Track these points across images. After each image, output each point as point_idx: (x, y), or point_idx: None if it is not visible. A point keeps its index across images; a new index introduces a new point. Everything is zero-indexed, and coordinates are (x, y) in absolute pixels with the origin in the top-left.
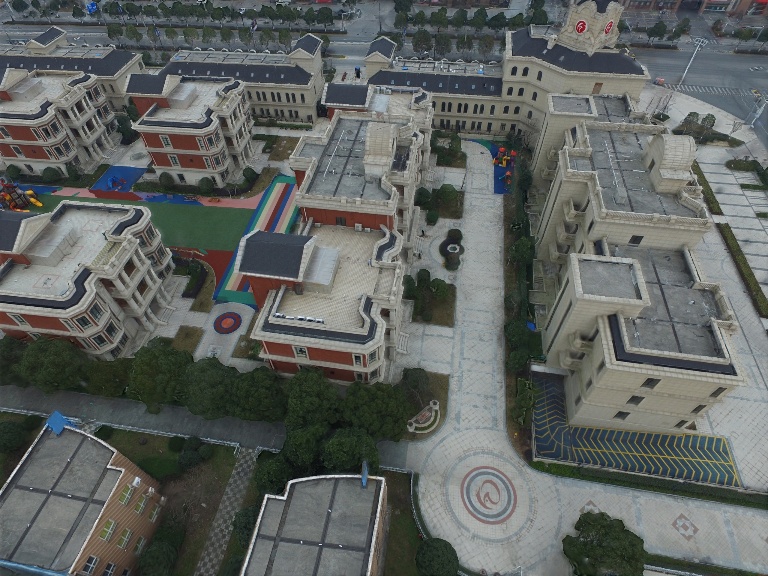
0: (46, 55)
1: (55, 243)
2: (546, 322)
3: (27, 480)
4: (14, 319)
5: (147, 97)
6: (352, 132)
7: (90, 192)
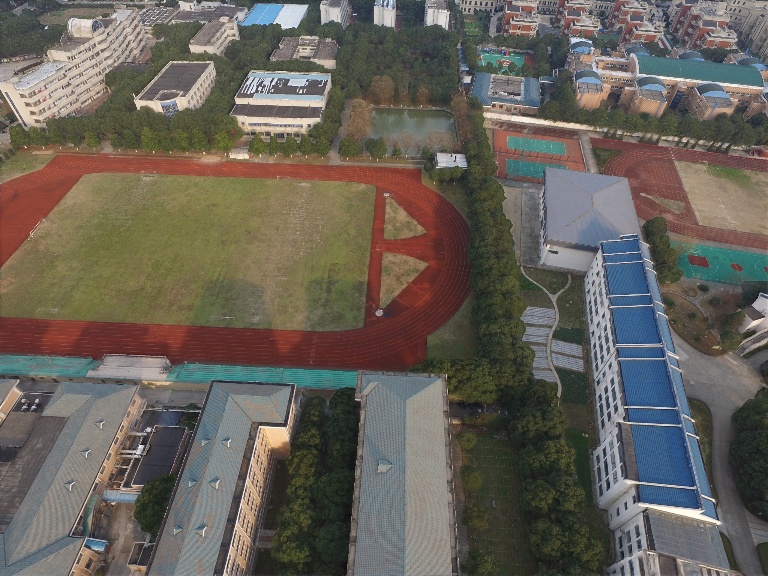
0: None
1: None
2: (761, 55)
3: (679, 51)
4: None
5: (623, 1)
6: None
7: None
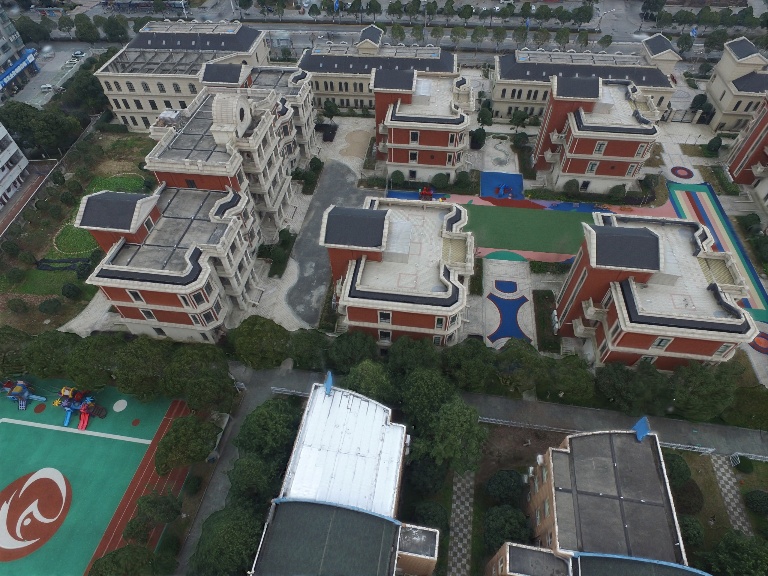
0: (378, 55)
1: (674, 260)
2: None
3: None
4: None
5: (575, 101)
6: None
7: (483, 200)
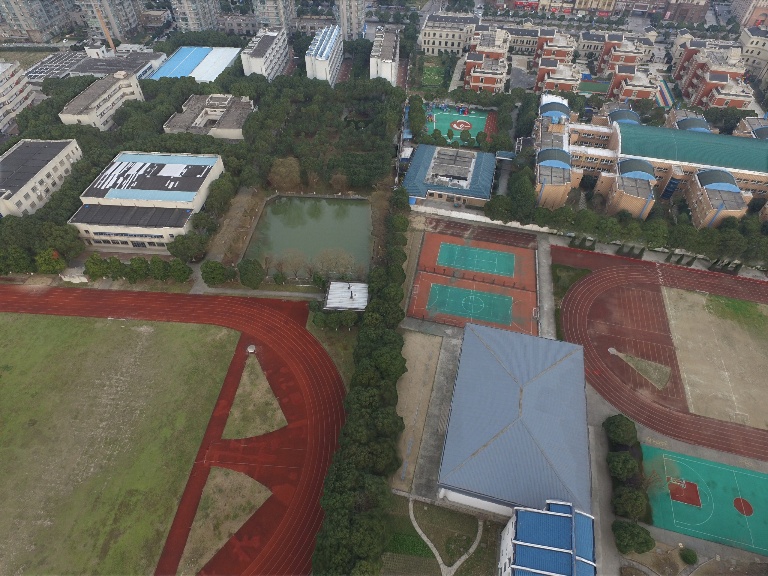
0: (532, 29)
1: None
2: None
3: None
4: None
5: (614, 43)
6: (712, 54)
7: None
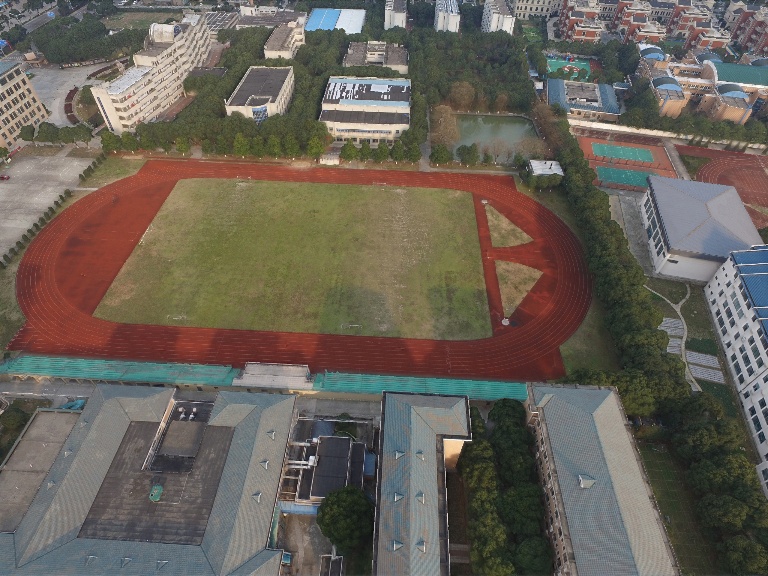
0: None
1: None
2: None
3: None
4: None
5: (684, 7)
6: None
7: None
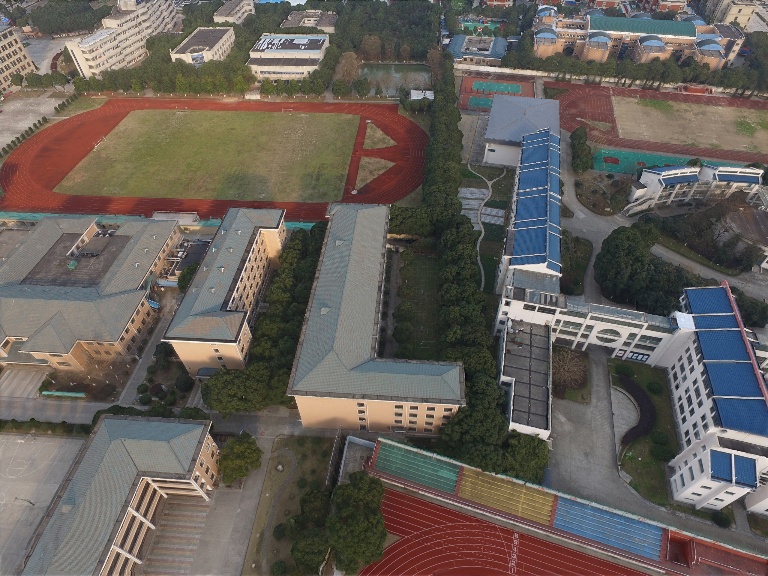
0: None
1: None
2: None
3: None
4: (603, 4)
5: None
6: None
7: None
